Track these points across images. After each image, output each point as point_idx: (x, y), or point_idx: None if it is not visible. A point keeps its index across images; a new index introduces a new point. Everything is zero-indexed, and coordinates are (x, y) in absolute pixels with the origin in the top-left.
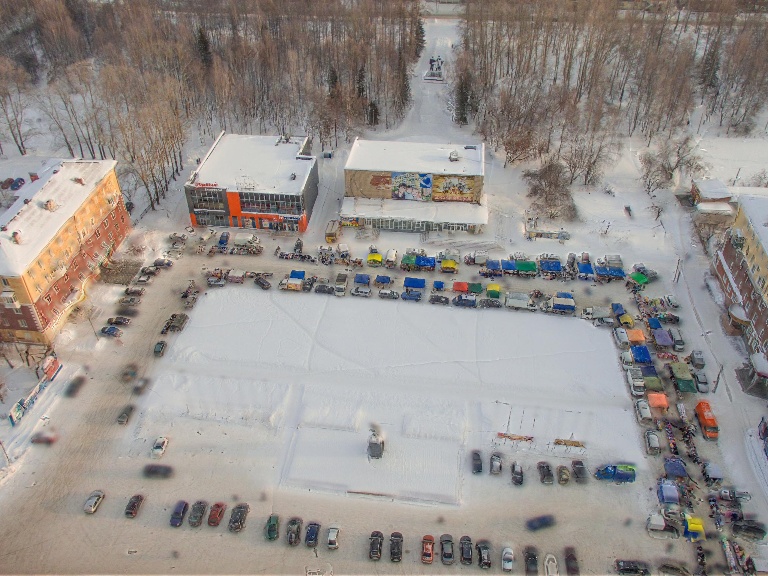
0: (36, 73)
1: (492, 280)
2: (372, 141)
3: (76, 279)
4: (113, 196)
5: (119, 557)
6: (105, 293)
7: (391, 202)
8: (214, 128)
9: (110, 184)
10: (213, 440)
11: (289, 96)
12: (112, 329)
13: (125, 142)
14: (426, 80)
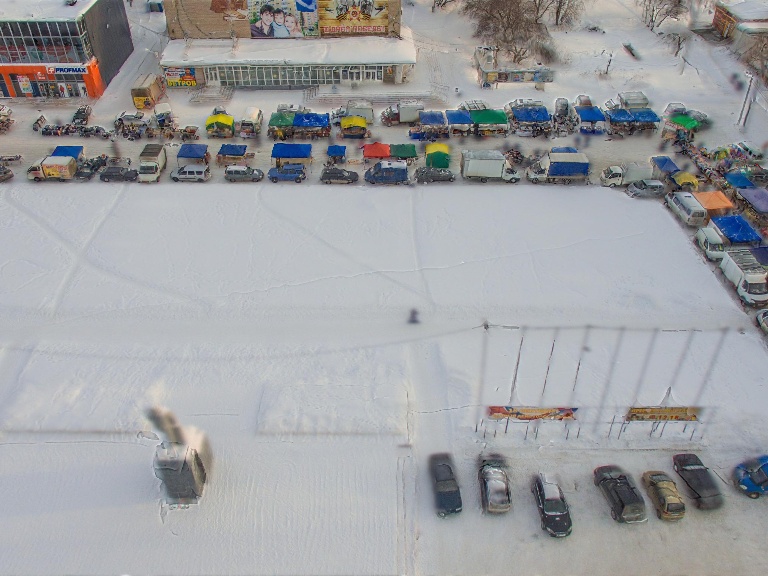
0: None
1: None
2: None
3: None
4: None
5: None
6: None
7: (250, 42)
8: None
9: None
10: None
11: None
12: None
13: None
14: None
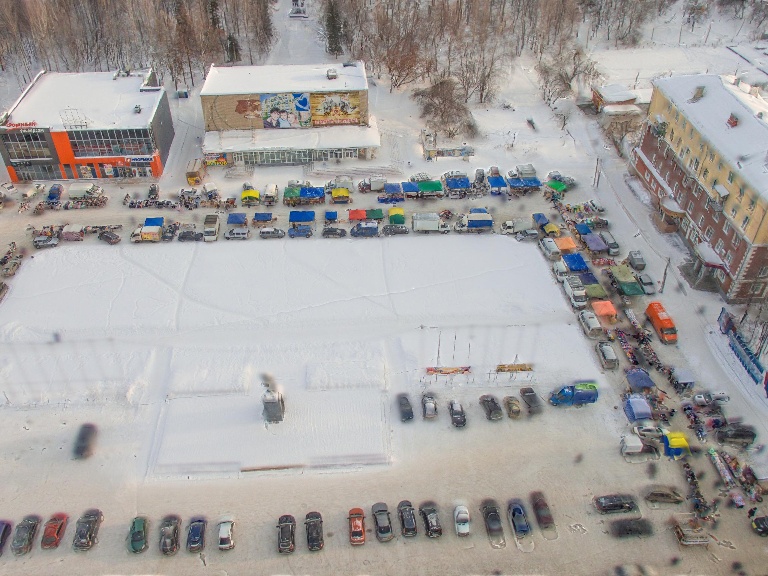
0: None
1: (394, 206)
2: (233, 67)
3: None
4: None
5: None
6: None
7: (264, 132)
8: (35, 72)
9: None
10: (47, 434)
11: (128, 31)
12: None
13: None
14: (292, 17)
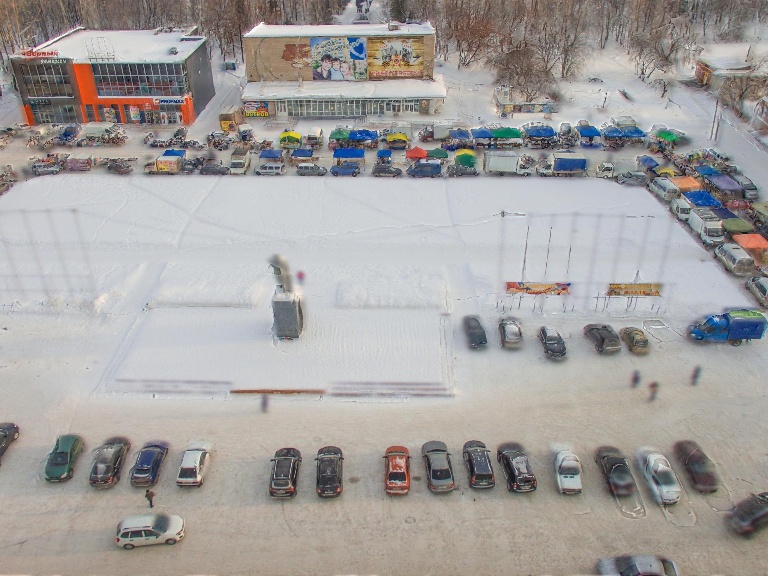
0: None
1: None
2: None
3: None
4: None
5: None
6: None
7: (312, 83)
8: None
9: None
10: None
11: (181, 9)
12: None
13: None
14: None
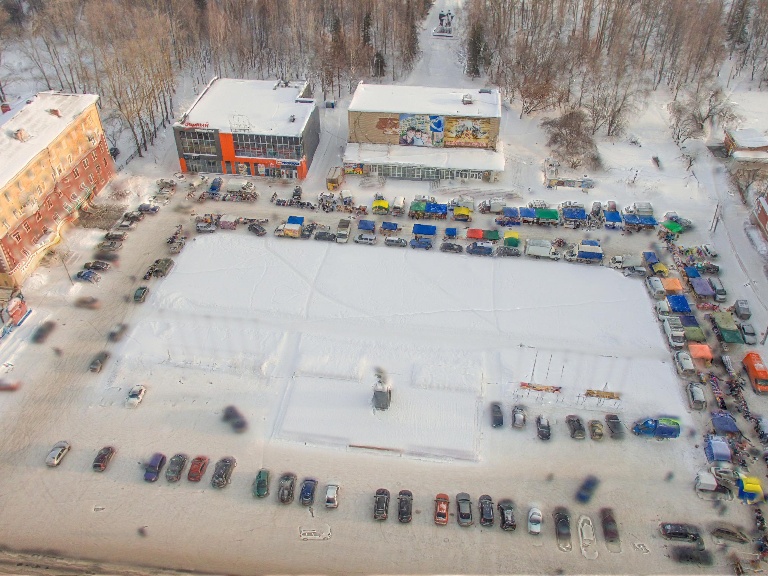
0: (21, 24)
1: (509, 228)
2: (378, 85)
3: (50, 220)
4: (94, 133)
5: (83, 514)
6: (83, 237)
7: (398, 148)
8: (208, 76)
9: (91, 120)
10: (197, 389)
11: (289, 44)
12: (89, 273)
13: (111, 87)
14: (435, 36)
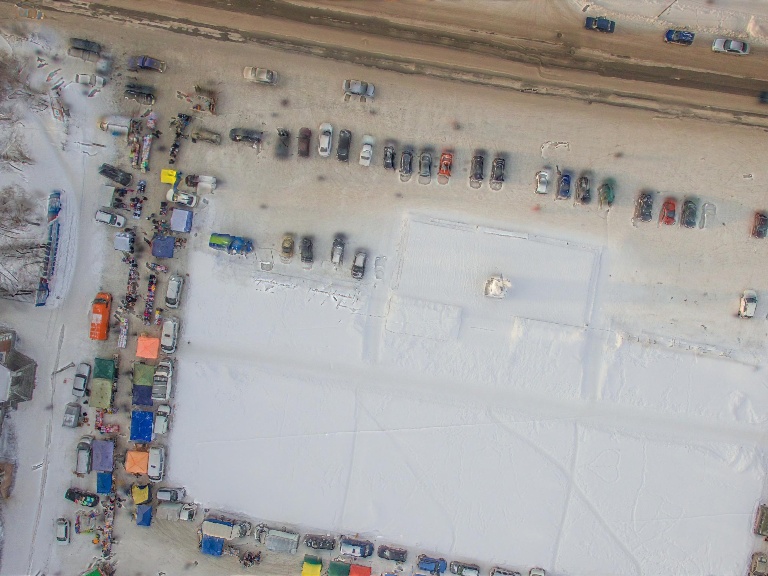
0: None
1: None
2: None
3: None
4: None
5: (761, 171)
6: None
7: None
8: None
9: None
10: (686, 316)
11: None
12: None
13: None
14: None
